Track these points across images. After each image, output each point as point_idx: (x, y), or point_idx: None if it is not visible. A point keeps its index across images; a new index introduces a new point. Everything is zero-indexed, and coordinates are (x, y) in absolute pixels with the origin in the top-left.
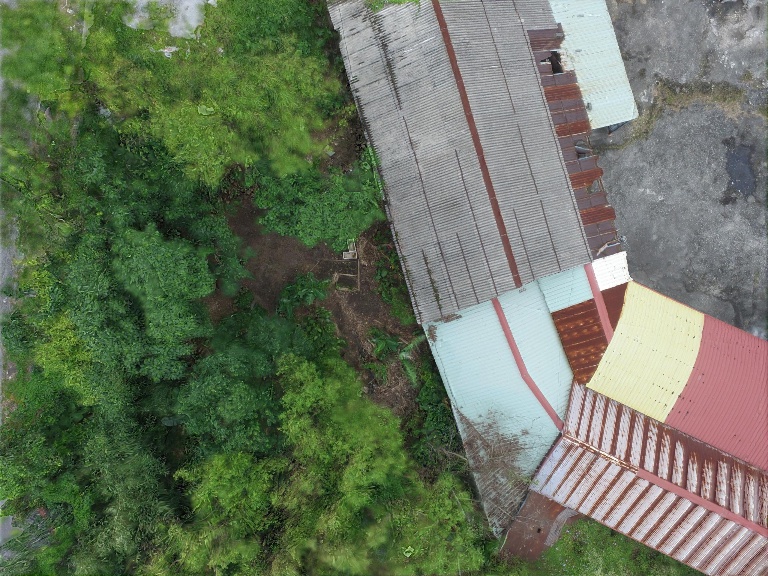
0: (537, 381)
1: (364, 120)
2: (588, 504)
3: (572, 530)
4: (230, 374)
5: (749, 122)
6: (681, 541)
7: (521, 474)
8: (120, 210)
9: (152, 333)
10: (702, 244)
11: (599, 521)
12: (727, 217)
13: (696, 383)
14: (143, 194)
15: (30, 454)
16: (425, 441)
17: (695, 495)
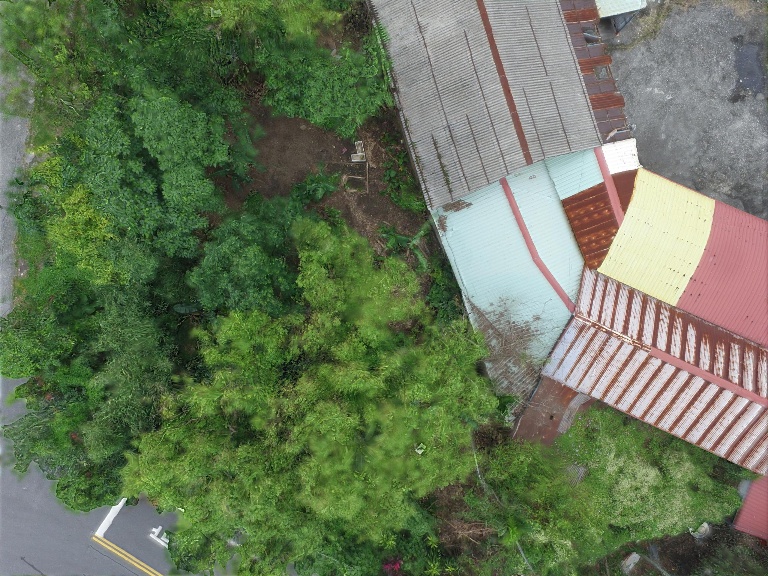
0: (548, 264)
1: (372, 8)
2: (600, 387)
3: (584, 418)
4: (243, 237)
5: (757, 20)
6: (694, 422)
7: (533, 362)
8: (132, 73)
9: (165, 202)
10: (711, 142)
11: (612, 405)
12: (736, 115)
13: (708, 265)
14: (154, 61)
15: (44, 331)
16: (436, 337)
17: (708, 373)
